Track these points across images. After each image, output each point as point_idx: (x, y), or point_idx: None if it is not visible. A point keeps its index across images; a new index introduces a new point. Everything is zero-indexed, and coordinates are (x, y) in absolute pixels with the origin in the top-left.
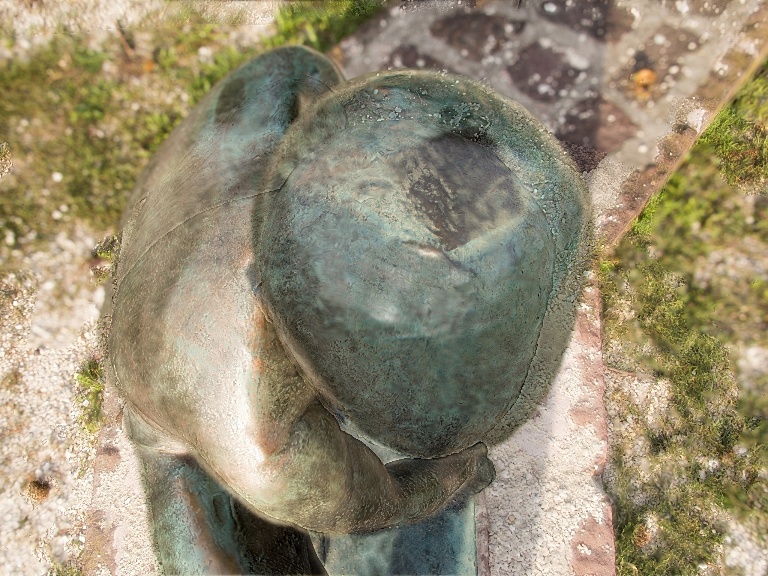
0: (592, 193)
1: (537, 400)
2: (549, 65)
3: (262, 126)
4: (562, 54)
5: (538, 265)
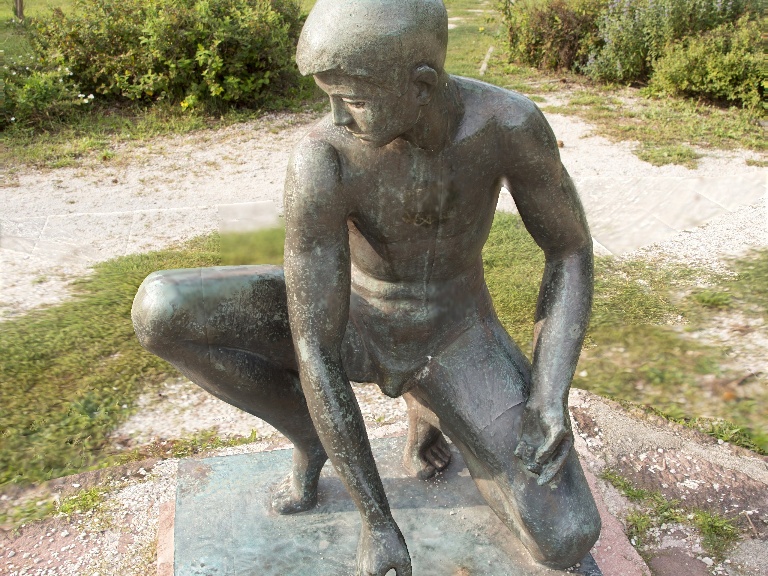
0: None
1: None
2: None
3: None
4: None
5: (375, 3)
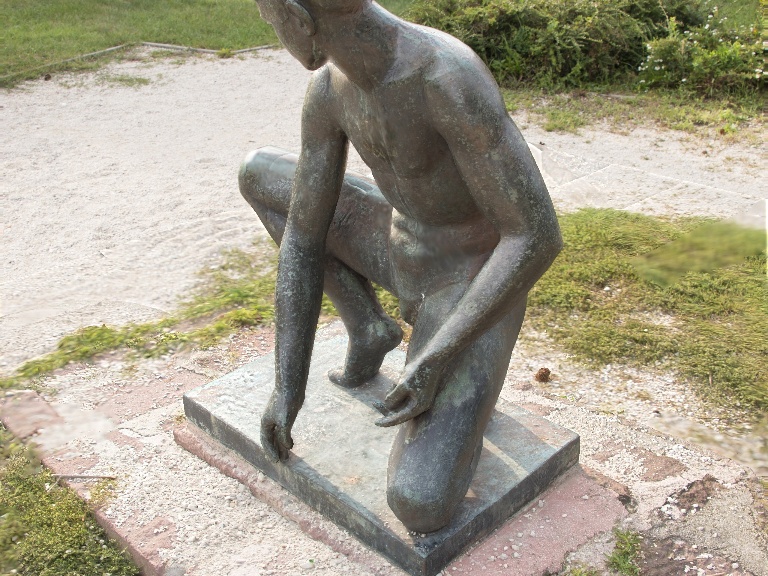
0: None
1: (276, 575)
2: None
3: (441, 35)
4: None
5: None
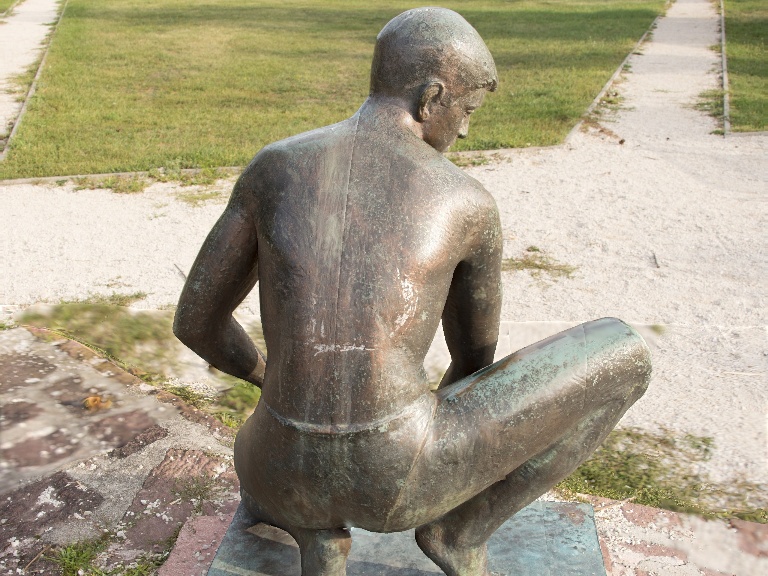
0: (190, 433)
1: None
2: (36, 446)
3: None
4: (29, 439)
5: None
